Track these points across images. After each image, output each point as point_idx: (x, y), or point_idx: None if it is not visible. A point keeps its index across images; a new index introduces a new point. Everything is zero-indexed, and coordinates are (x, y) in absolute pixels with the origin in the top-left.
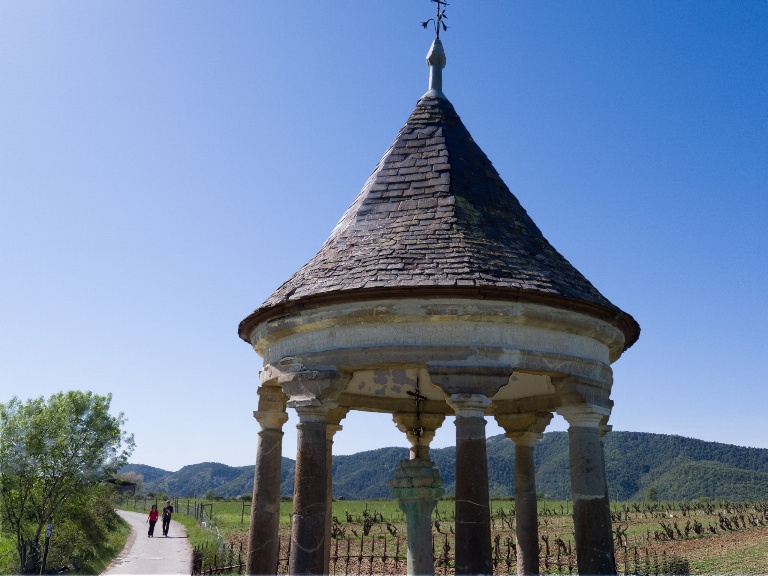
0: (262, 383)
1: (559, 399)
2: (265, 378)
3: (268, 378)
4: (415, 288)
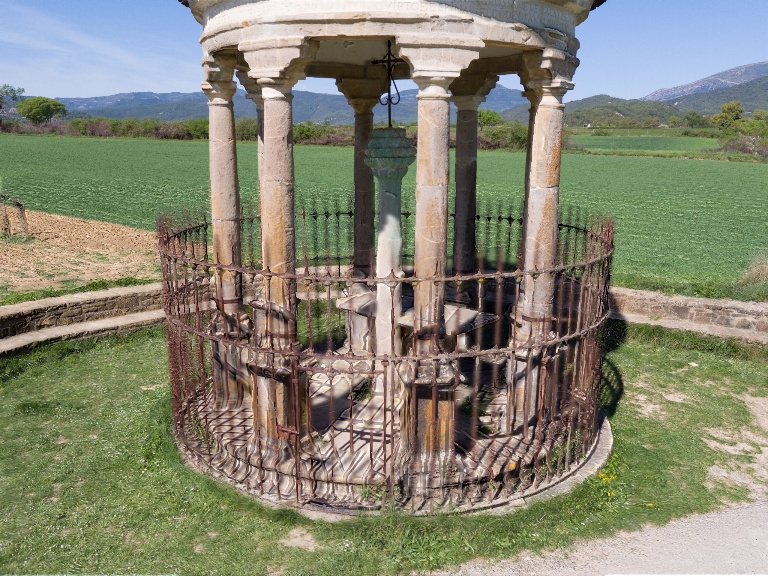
0: (493, 39)
1: (327, 69)
2: (513, 38)
3: (522, 41)
4: (593, 4)
